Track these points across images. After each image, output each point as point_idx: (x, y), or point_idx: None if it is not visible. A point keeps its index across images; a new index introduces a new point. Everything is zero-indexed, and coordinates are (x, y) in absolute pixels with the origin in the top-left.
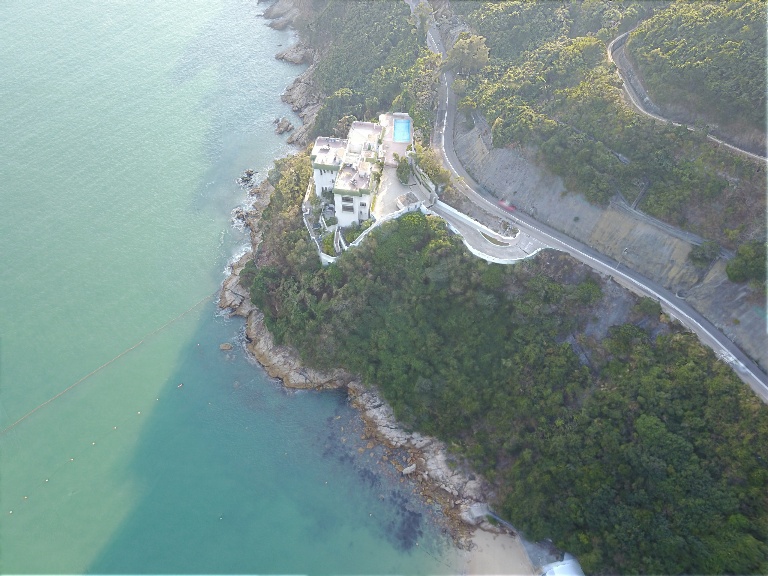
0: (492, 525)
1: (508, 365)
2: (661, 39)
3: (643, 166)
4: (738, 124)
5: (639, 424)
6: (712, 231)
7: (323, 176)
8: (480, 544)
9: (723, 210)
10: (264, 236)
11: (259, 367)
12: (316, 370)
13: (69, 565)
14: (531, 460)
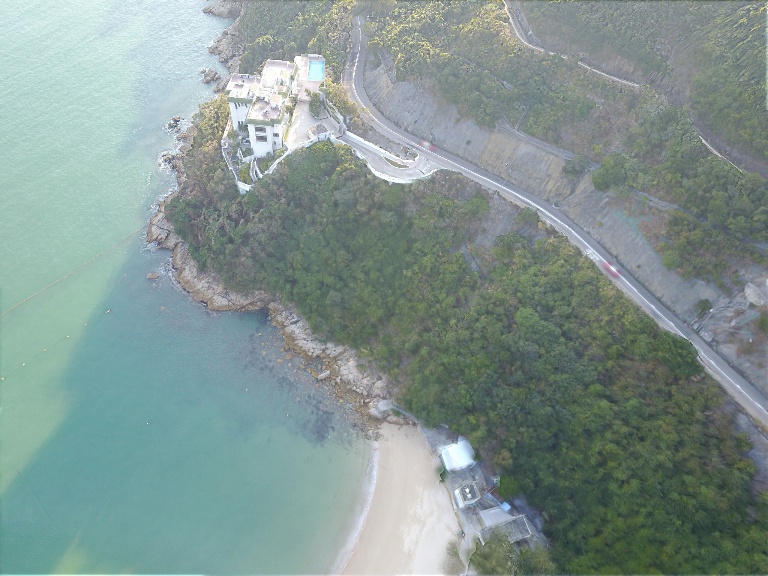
0: (396, 417)
1: (408, 275)
2: None
3: (523, 91)
4: (605, 52)
5: (517, 316)
6: (582, 147)
7: (238, 110)
8: (386, 434)
9: (591, 128)
10: (187, 173)
11: (184, 293)
12: (238, 293)
13: (2, 468)
14: (428, 356)
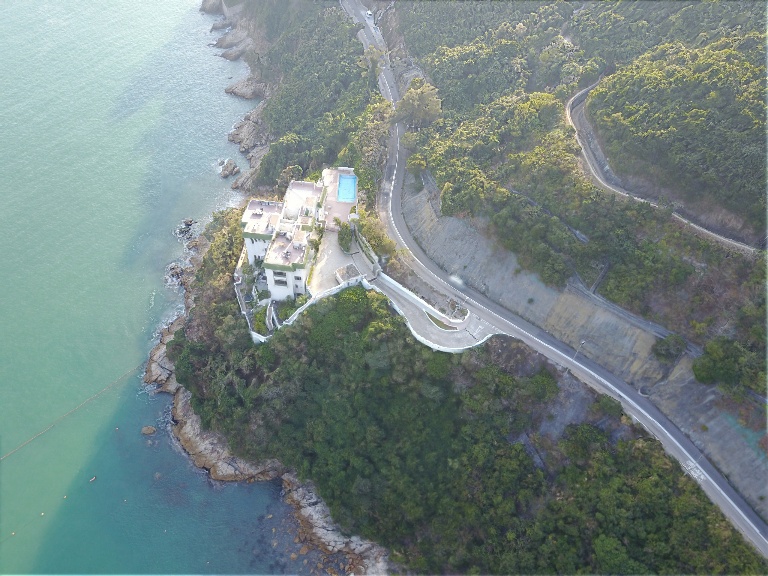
0: None
1: (455, 467)
2: (622, 102)
3: (602, 247)
4: (705, 202)
5: (597, 546)
6: (677, 323)
7: (255, 244)
8: None
9: (689, 299)
10: (195, 303)
11: (184, 455)
12: (246, 461)
13: None
14: None
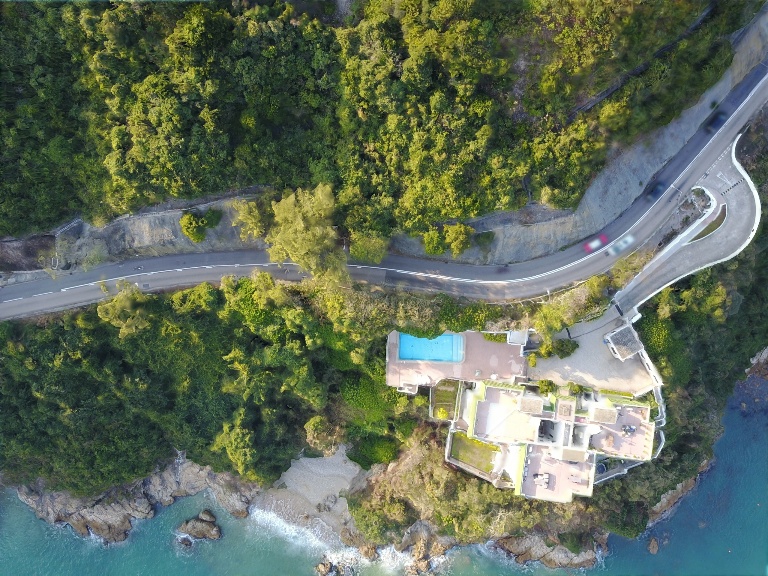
0: None
1: None
2: None
3: None
4: None
5: None
6: None
7: None
8: None
9: None
10: None
11: (680, 503)
12: None
13: None
14: None
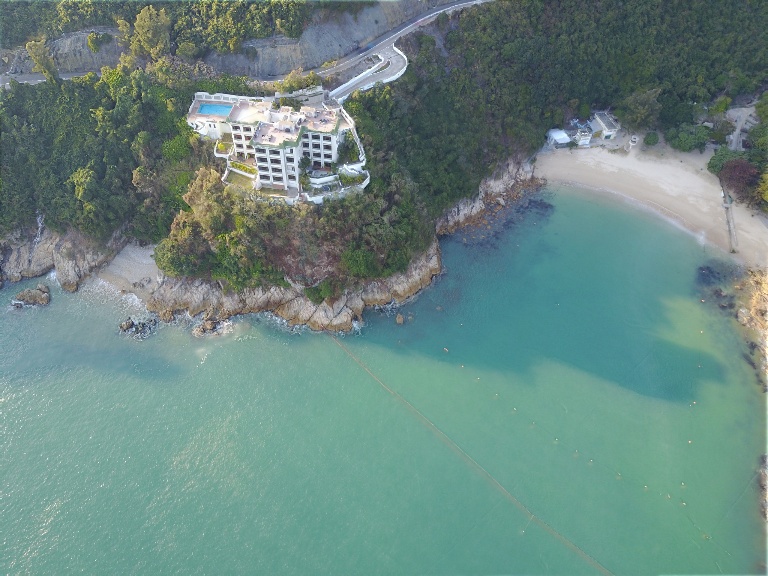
0: None
1: (459, 106)
2: None
3: None
4: None
5: (507, 54)
6: None
7: (297, 151)
8: (542, 175)
9: None
10: None
11: (421, 293)
12: (431, 244)
13: (620, 397)
14: None
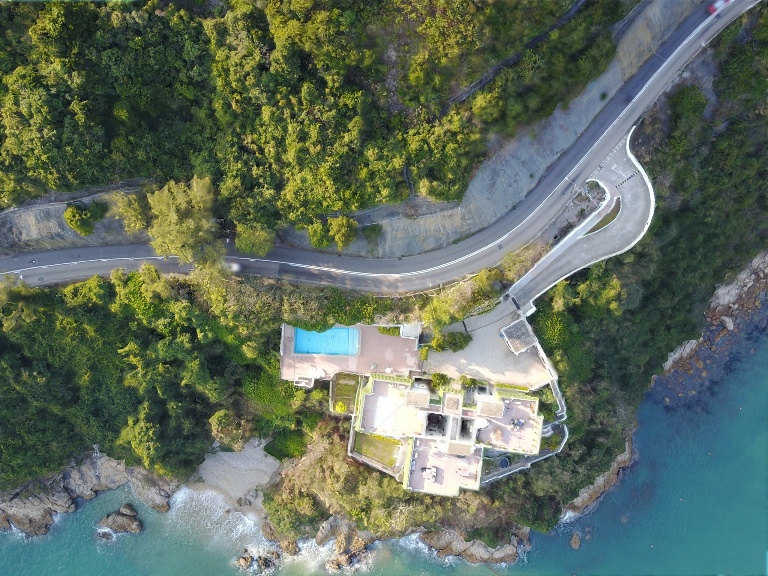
0: None
1: (713, 215)
2: None
3: None
4: None
5: None
6: None
7: None
8: None
9: None
10: None
11: (603, 497)
12: None
13: None
14: None
